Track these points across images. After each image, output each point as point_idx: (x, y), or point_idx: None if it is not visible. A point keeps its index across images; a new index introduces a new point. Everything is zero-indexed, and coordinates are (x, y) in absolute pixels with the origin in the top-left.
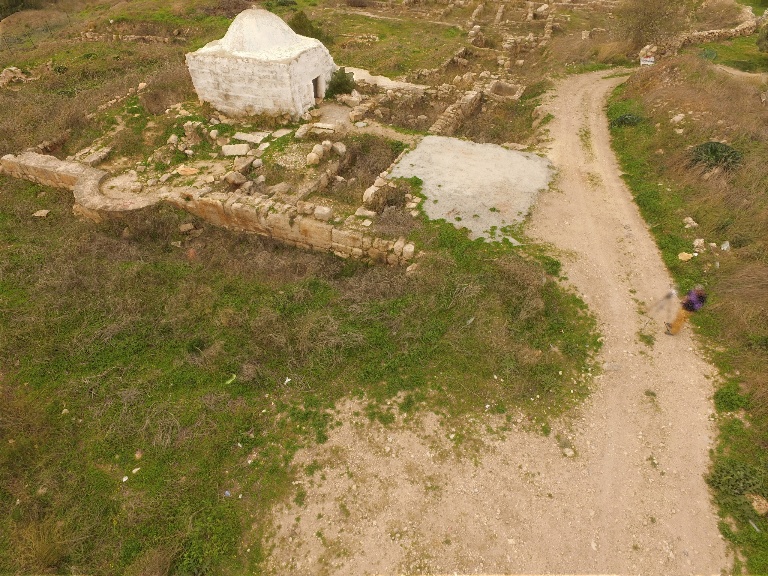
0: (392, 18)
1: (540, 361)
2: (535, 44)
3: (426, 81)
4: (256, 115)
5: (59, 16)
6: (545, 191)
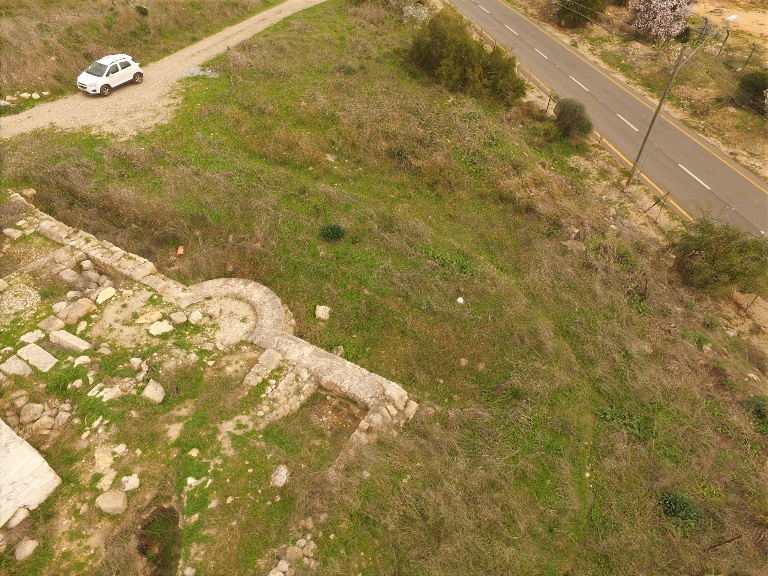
0: None
1: (24, 141)
2: None
3: None
4: None
5: None
6: None
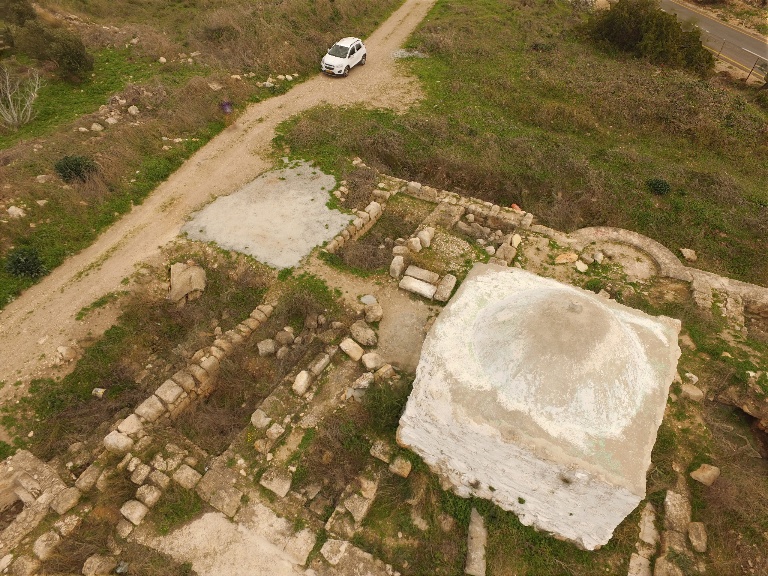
0: None
1: None
2: None
3: (160, 564)
4: None
5: None
6: (224, 195)
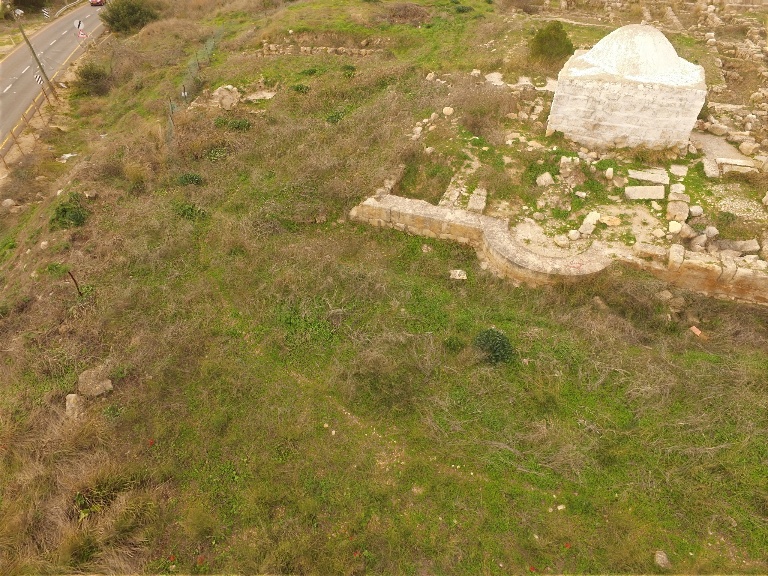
0: (599, 25)
1: None
2: None
3: (734, 100)
4: (629, 148)
5: (197, 25)
6: None
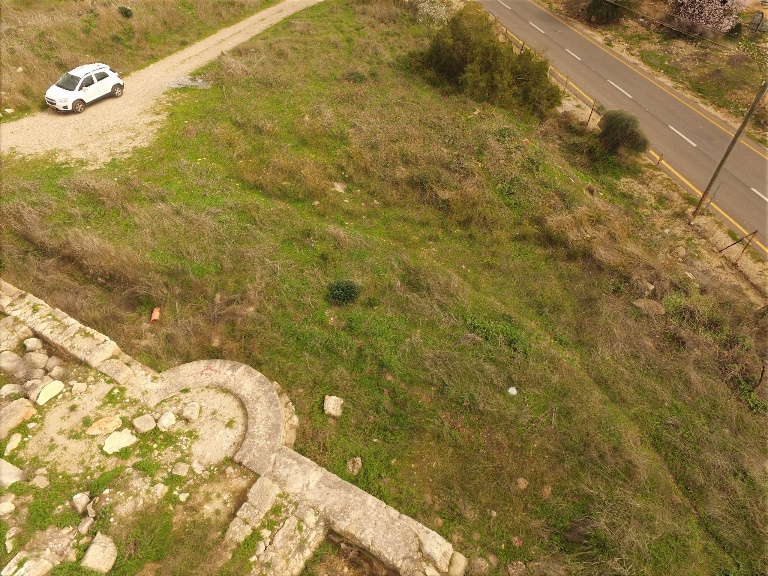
0: None
1: None
2: None
3: None
4: None
5: None
6: None
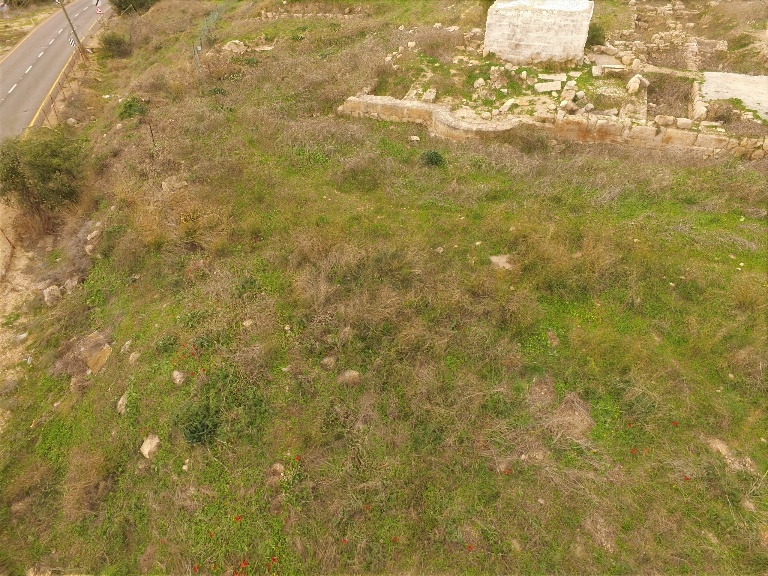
0: None
1: None
2: (680, 12)
3: (636, 38)
4: (542, 61)
5: None
6: None
